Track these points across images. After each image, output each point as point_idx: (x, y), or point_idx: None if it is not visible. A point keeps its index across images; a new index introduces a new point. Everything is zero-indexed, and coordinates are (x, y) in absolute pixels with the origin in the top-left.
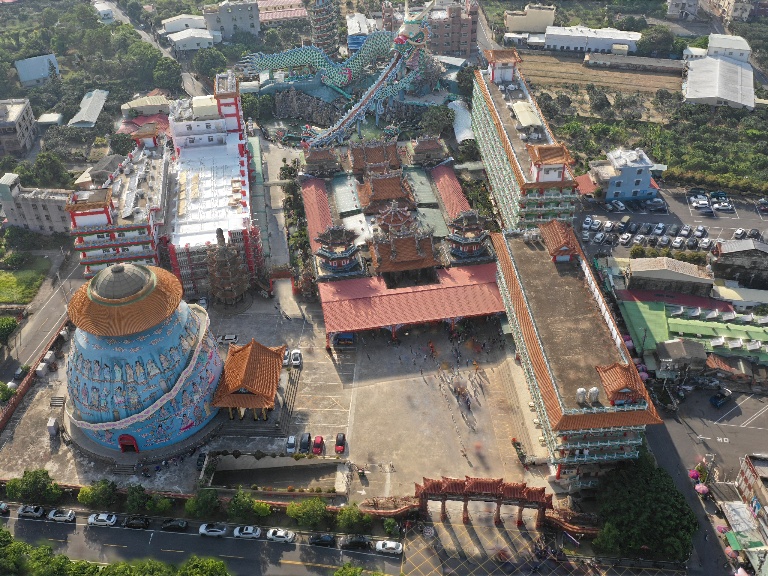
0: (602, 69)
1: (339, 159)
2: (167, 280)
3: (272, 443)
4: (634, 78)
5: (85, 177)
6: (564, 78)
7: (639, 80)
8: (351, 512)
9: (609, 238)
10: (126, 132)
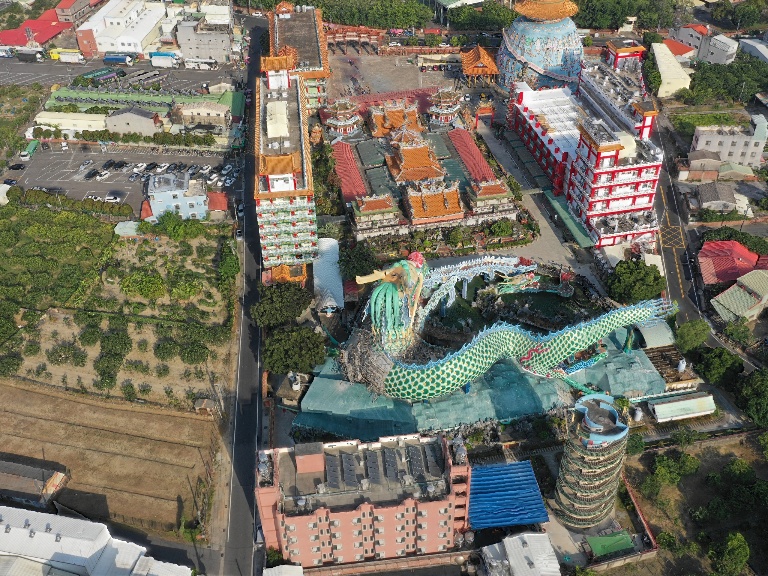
0: (42, 466)
1: (469, 189)
2: (528, 9)
3: (461, 69)
4: (6, 435)
5: (741, 200)
6: (129, 434)
7: (2, 429)
8: (413, 37)
9: (220, 166)
10: (764, 260)
